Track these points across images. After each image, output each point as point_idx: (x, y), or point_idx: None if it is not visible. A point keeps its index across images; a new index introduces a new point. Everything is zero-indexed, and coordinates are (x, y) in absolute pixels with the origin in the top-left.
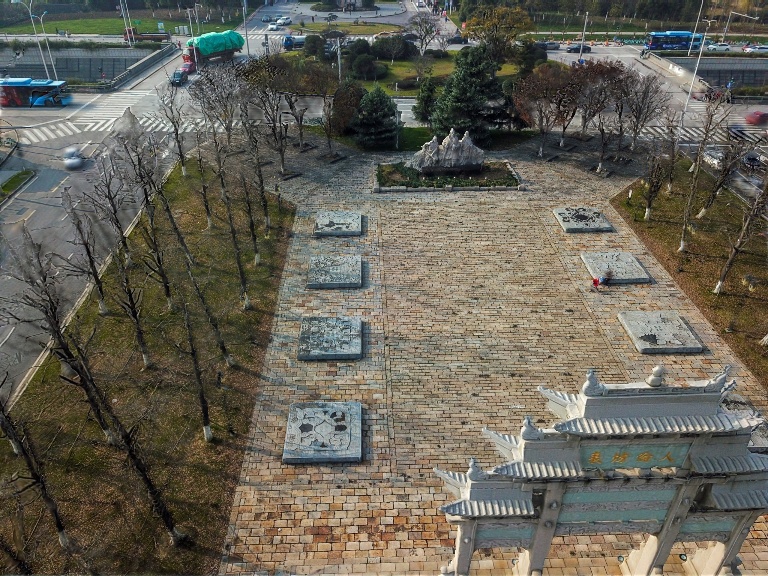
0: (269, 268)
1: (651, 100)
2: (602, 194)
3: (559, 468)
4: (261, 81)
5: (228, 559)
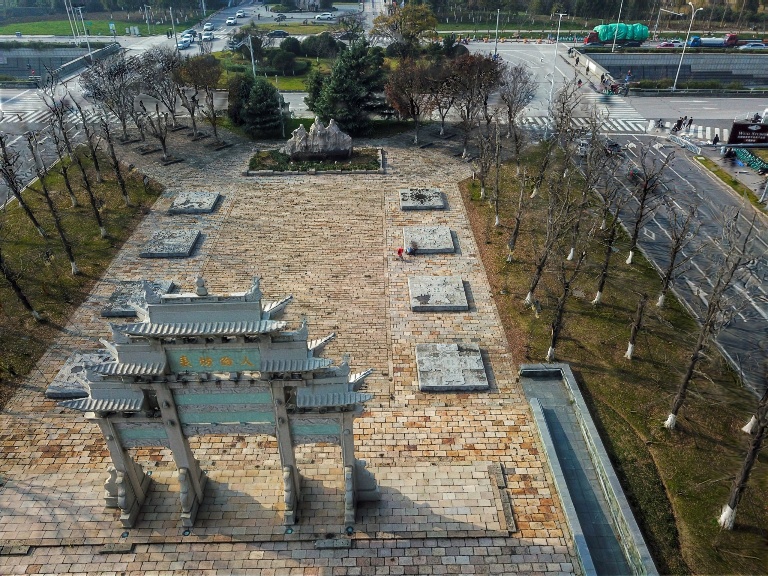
0: (112, 240)
1: (523, 90)
2: (455, 177)
3: (145, 367)
4: (156, 74)
5: None
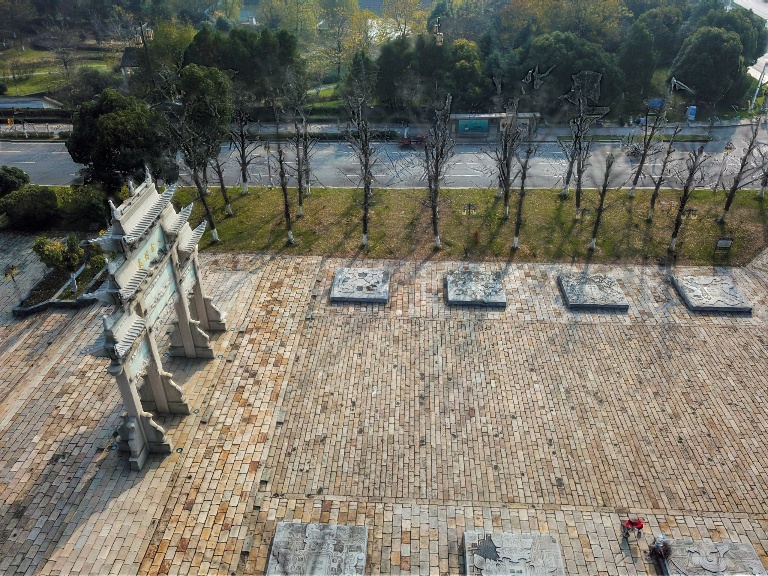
0: (586, 255)
1: None
2: None
3: None
4: None
5: (273, 257)
